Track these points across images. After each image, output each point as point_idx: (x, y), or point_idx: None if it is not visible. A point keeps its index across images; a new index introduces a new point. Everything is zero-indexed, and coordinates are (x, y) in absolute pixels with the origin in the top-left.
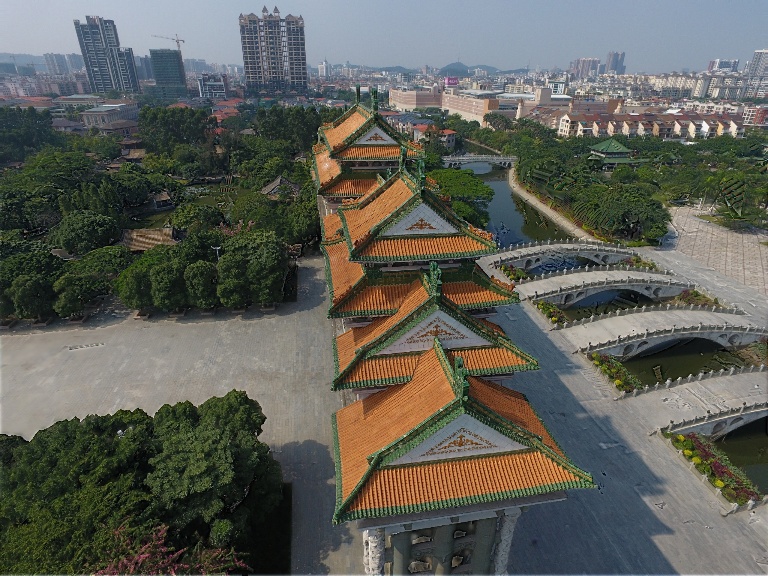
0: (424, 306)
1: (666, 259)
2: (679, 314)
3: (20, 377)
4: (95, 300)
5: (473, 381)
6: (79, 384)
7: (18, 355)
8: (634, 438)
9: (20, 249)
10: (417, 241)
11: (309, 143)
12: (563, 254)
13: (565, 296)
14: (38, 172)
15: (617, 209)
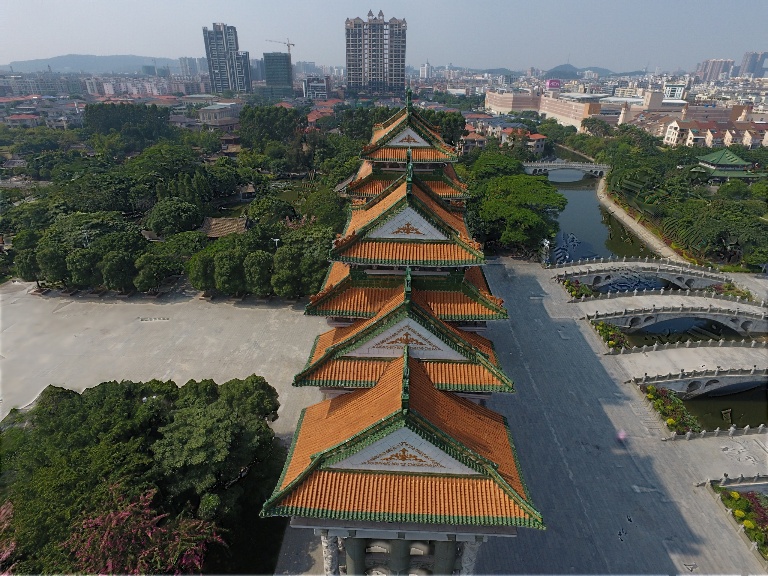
0: (395, 312)
1: (767, 289)
2: (766, 353)
3: (97, 340)
4: (171, 279)
5: (440, 395)
6: (141, 352)
7: (100, 321)
8: (676, 486)
9: (116, 228)
10: (403, 245)
11: None
12: (639, 273)
13: (631, 319)
14: (146, 162)
15: (713, 228)
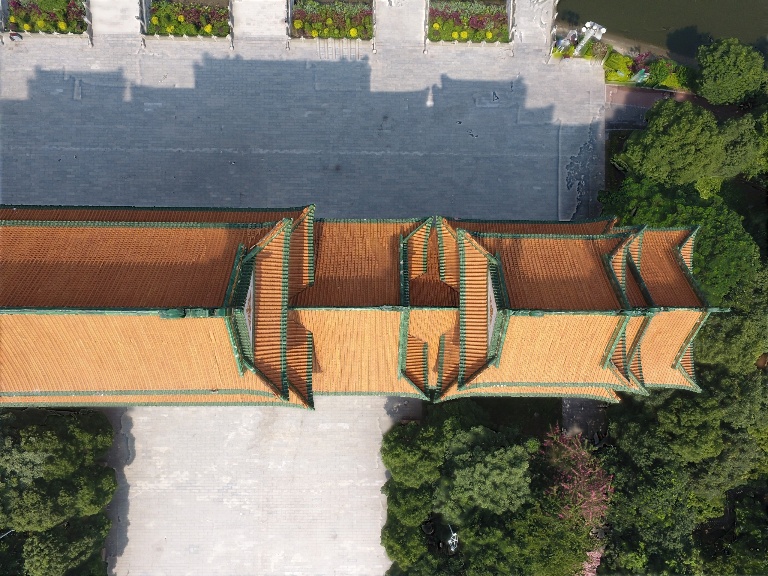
0: None
1: None
2: None
3: None
4: None
5: None
6: None
7: None
8: (427, 69)
9: None
10: None
11: None
12: None
13: None
14: None
15: None
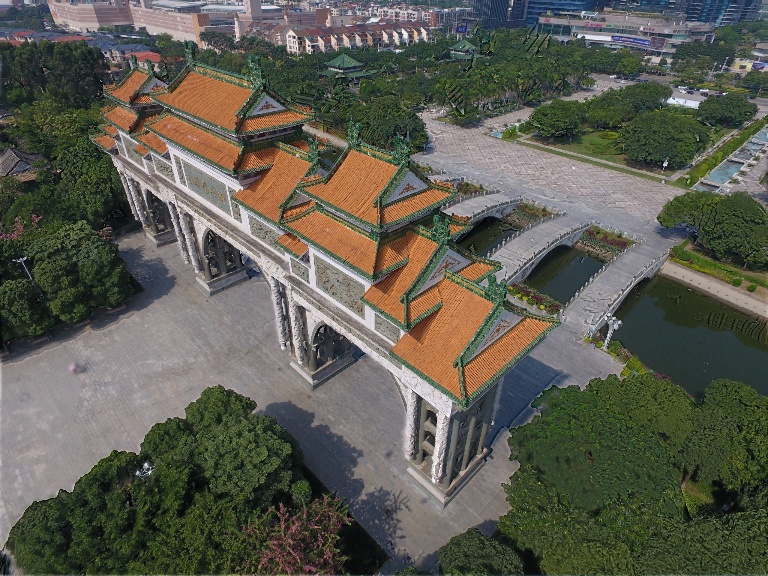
0: (438, 249)
1: (435, 161)
2: (469, 203)
3: None
4: None
5: None
6: None
7: None
8: None
9: None
10: (407, 202)
11: (3, 94)
12: None
13: None
14: None
15: (387, 125)
